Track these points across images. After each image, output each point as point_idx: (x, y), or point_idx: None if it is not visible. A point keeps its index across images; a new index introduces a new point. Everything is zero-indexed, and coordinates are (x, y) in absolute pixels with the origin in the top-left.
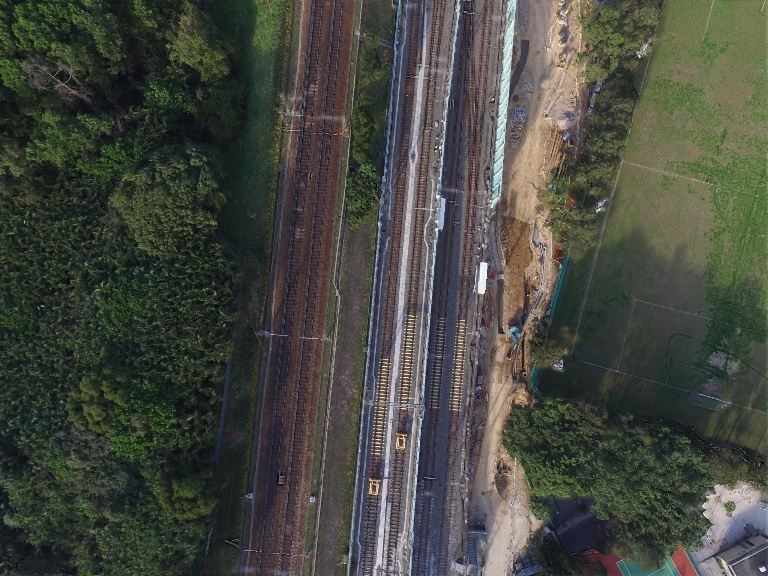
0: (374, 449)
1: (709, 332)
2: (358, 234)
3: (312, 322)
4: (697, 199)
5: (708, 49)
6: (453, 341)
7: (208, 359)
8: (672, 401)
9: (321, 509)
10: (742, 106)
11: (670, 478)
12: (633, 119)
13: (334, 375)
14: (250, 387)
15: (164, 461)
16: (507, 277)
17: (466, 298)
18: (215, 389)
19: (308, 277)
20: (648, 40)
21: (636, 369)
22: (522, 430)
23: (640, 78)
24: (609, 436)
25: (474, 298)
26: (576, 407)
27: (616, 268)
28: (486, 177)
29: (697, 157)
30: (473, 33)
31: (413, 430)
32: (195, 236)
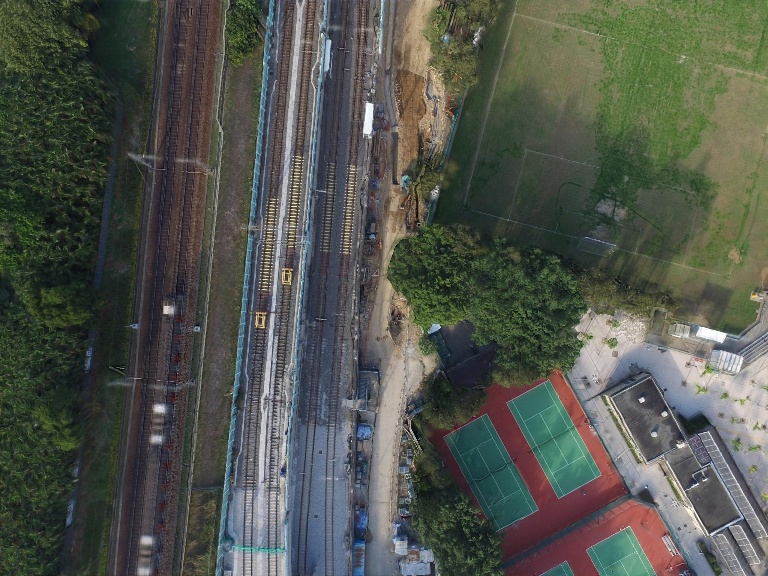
0: (261, 285)
1: (598, 180)
2: (243, 73)
3: (195, 156)
4: (587, 50)
5: None
6: (343, 186)
7: (78, 174)
8: (561, 248)
9: (206, 339)
10: None
11: (539, 295)
12: None
13: (218, 209)
14: (133, 220)
15: (34, 272)
16: (401, 129)
17: (356, 144)
18: (89, 209)
19: (190, 112)
20: None
21: (527, 218)
22: (401, 258)
23: None
24: (481, 255)
25: (364, 144)
26: (450, 230)
27: (508, 119)
28: (375, 24)
29: (588, 9)
30: None
31: (300, 267)
32: (64, 54)
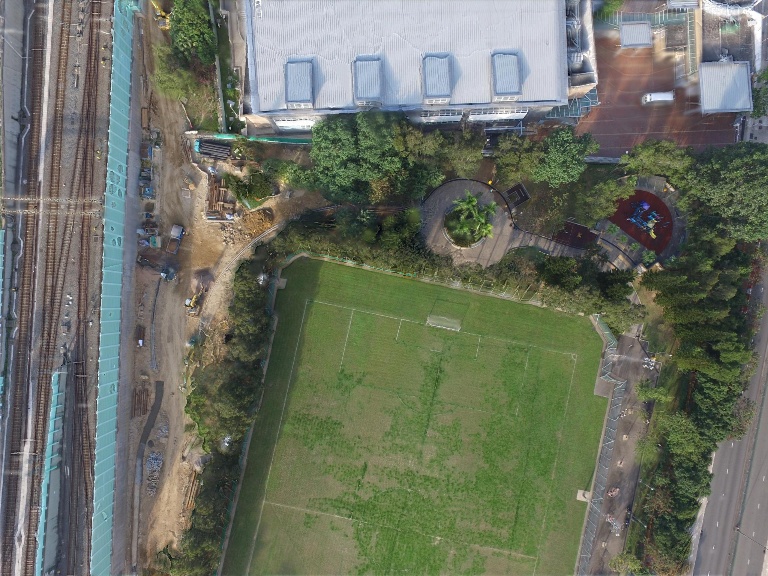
0: None
1: None
2: None
3: None
4: (340, 536)
5: (345, 380)
6: None
7: None
8: None
9: None
10: (381, 437)
11: None
12: (273, 457)
13: None
14: None
15: None
16: None
17: None
18: None
19: None
20: (232, 430)
21: None
22: None
23: (279, 414)
24: None
25: None
26: None
27: None
28: None
29: (339, 493)
30: (85, 397)
31: None
32: None
